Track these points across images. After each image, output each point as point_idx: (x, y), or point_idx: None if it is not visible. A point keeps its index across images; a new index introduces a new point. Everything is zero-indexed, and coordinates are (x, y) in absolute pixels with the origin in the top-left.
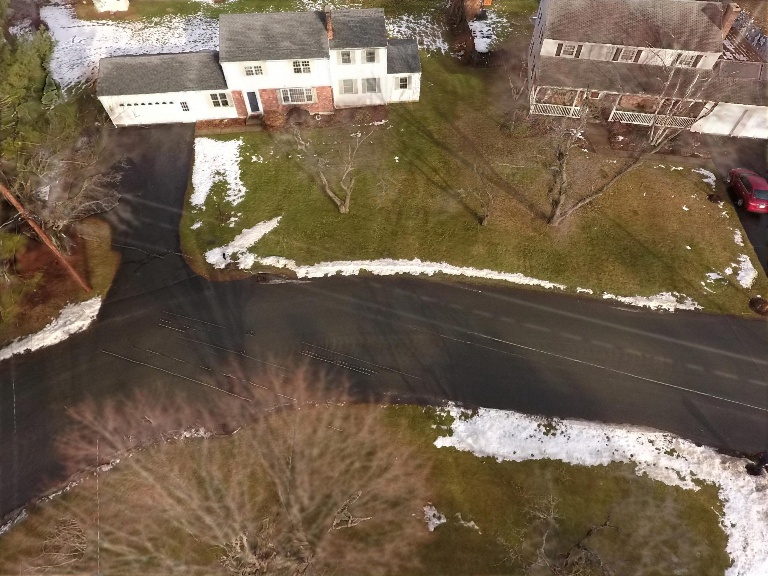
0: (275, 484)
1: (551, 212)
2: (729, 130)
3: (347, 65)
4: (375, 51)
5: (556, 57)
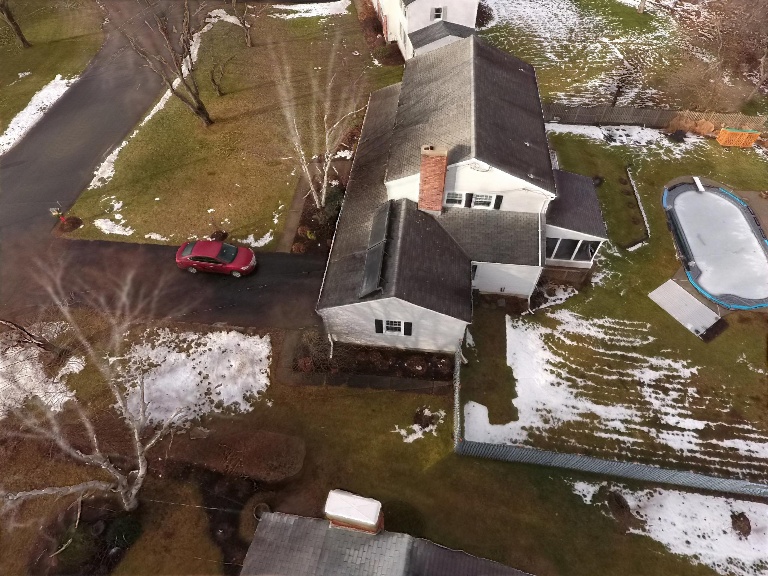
0: (68, 38)
1: None
2: None
3: None
4: None
5: None
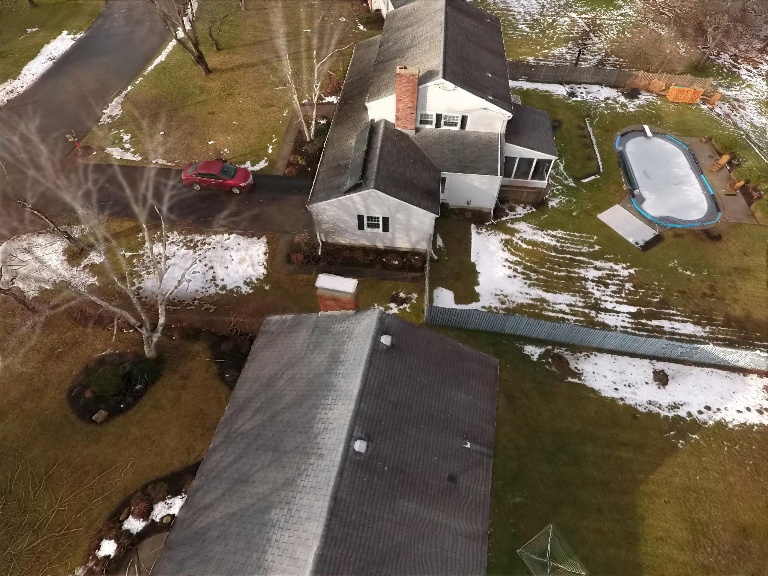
0: (71, 0)
1: None
2: None
3: None
4: None
5: None
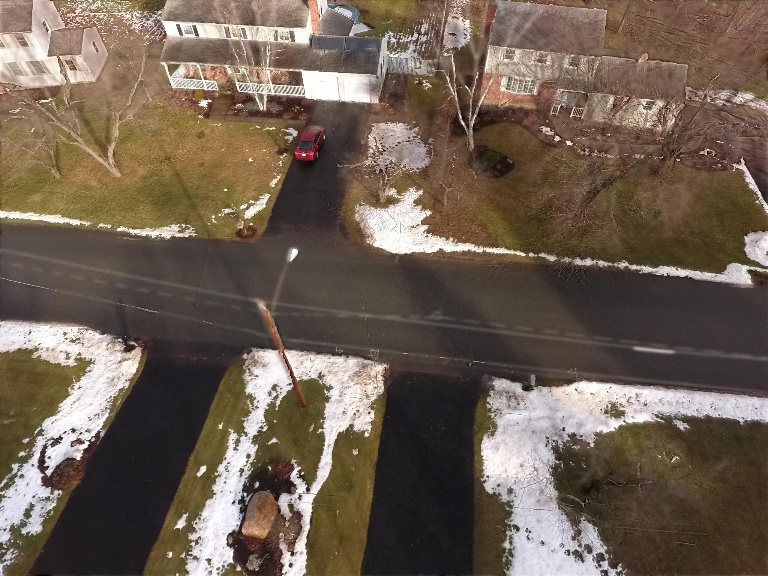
0: None
1: None
2: (337, 96)
3: (3, 49)
4: (23, 36)
5: (181, 36)
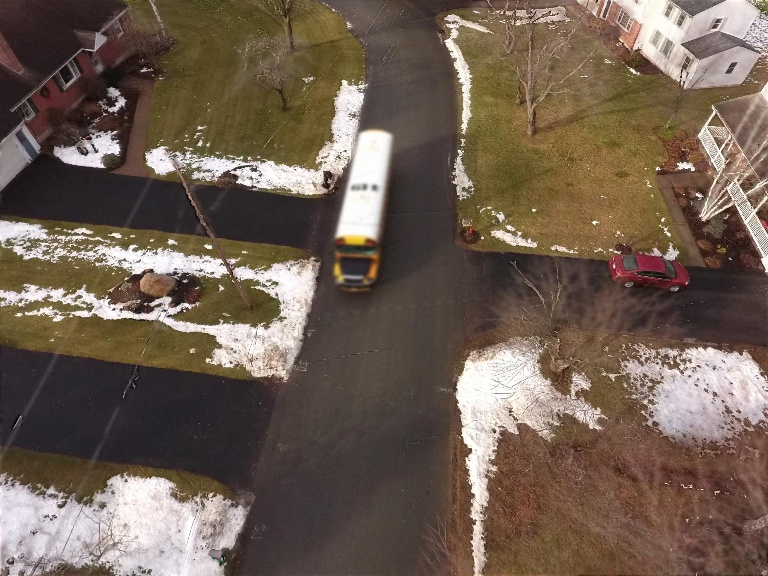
0: (325, 42)
1: None
2: None
3: (666, 18)
4: None
5: (767, 102)
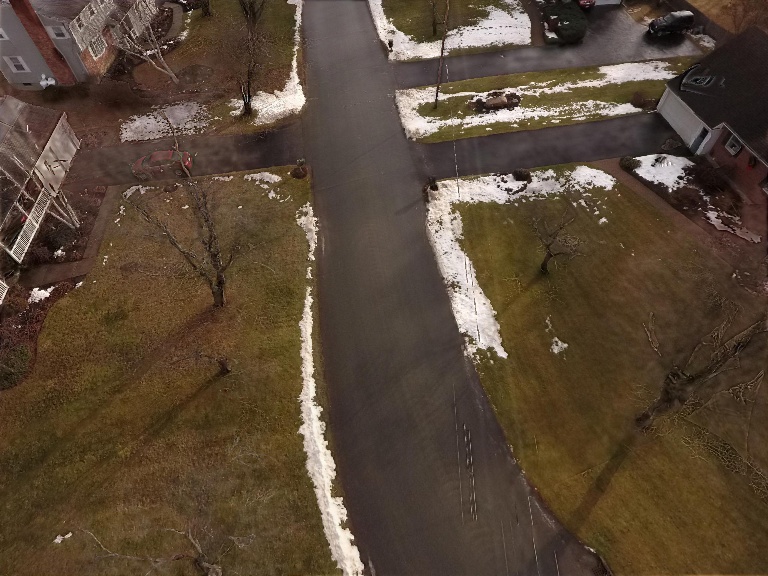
0: (611, 477)
1: (218, 297)
2: (61, 170)
3: None
4: None
5: None
